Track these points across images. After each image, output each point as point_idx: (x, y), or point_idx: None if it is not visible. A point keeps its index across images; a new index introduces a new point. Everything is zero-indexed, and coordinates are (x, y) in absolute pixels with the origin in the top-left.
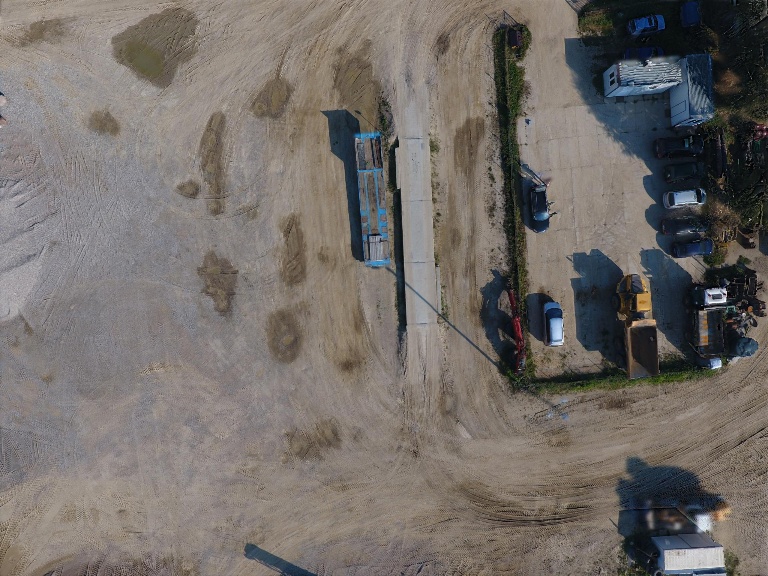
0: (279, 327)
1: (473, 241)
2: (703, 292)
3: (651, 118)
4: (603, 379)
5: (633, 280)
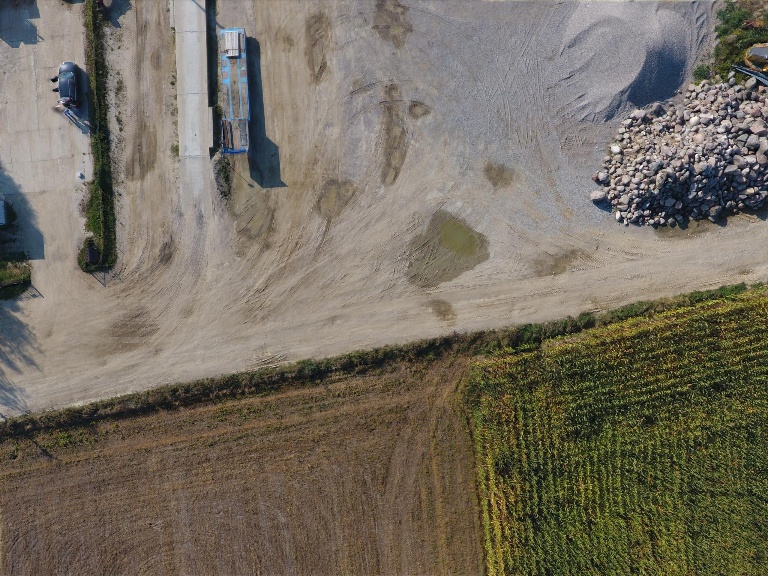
0: None
1: (139, 57)
2: None
3: None
4: None
5: None
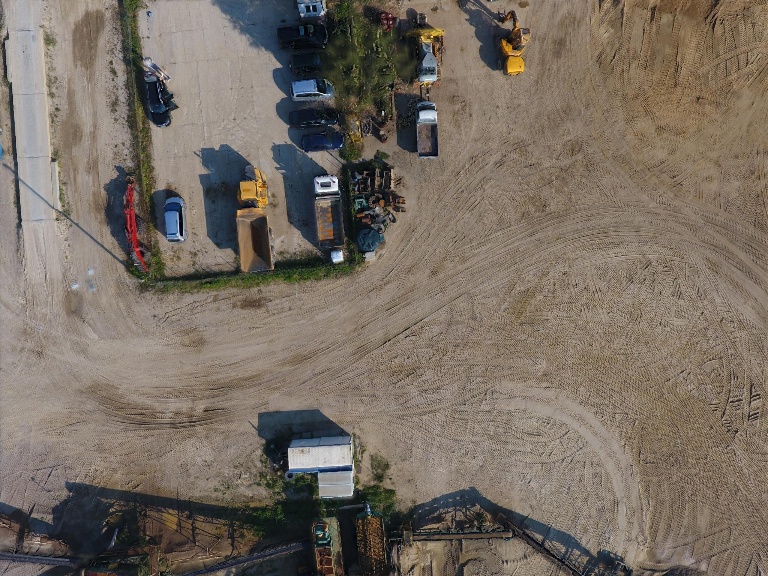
0: None
1: (95, 137)
2: None
3: (279, 10)
4: (232, 276)
5: (246, 170)
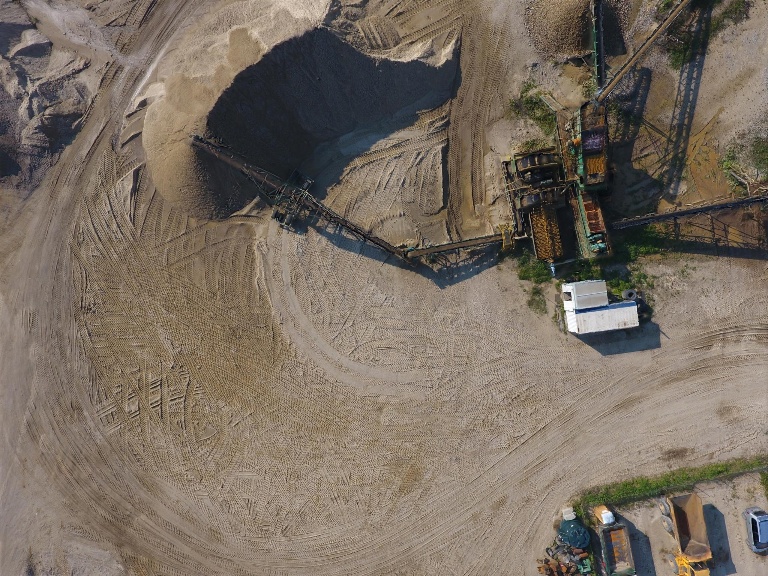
0: None
1: None
2: None
3: None
4: (700, 481)
5: None
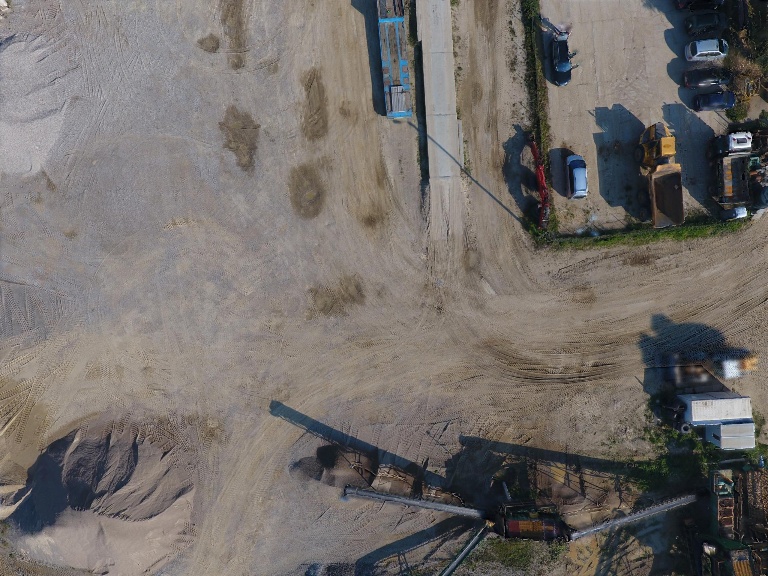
0: (301, 182)
1: (495, 95)
2: (727, 137)
3: None
4: (627, 233)
5: (657, 127)
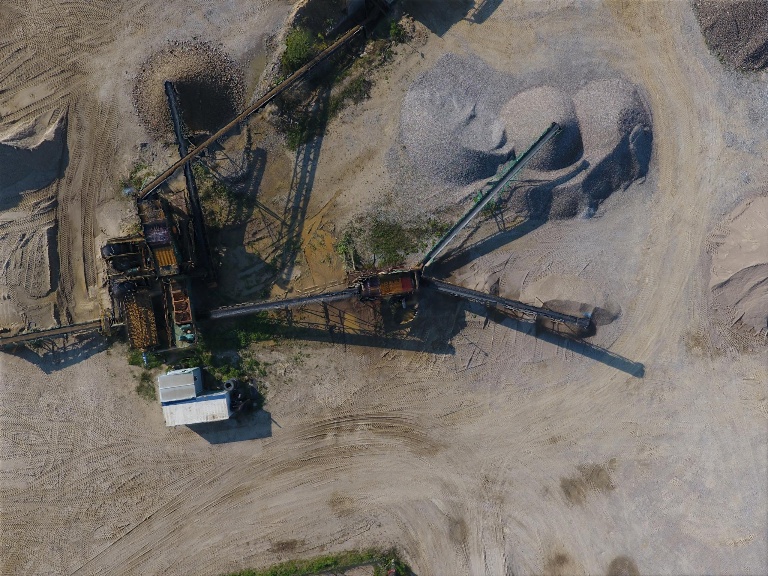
0: None
1: None
2: None
3: None
4: None
5: None
